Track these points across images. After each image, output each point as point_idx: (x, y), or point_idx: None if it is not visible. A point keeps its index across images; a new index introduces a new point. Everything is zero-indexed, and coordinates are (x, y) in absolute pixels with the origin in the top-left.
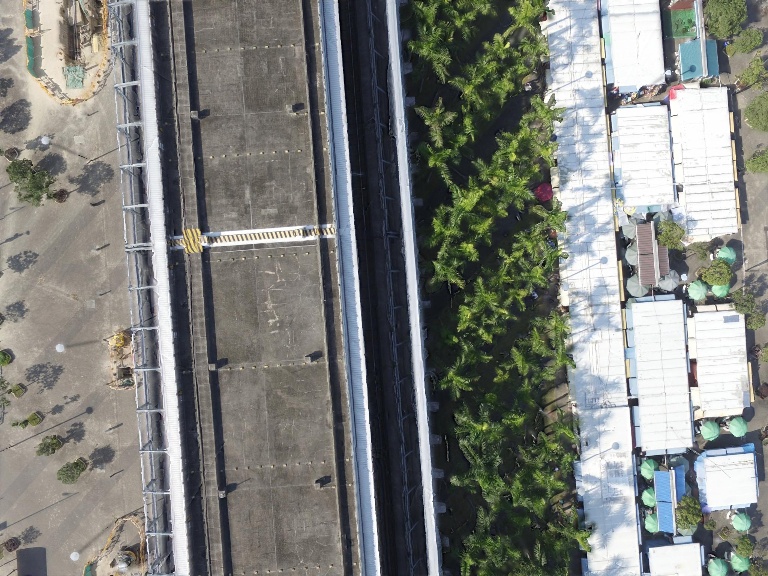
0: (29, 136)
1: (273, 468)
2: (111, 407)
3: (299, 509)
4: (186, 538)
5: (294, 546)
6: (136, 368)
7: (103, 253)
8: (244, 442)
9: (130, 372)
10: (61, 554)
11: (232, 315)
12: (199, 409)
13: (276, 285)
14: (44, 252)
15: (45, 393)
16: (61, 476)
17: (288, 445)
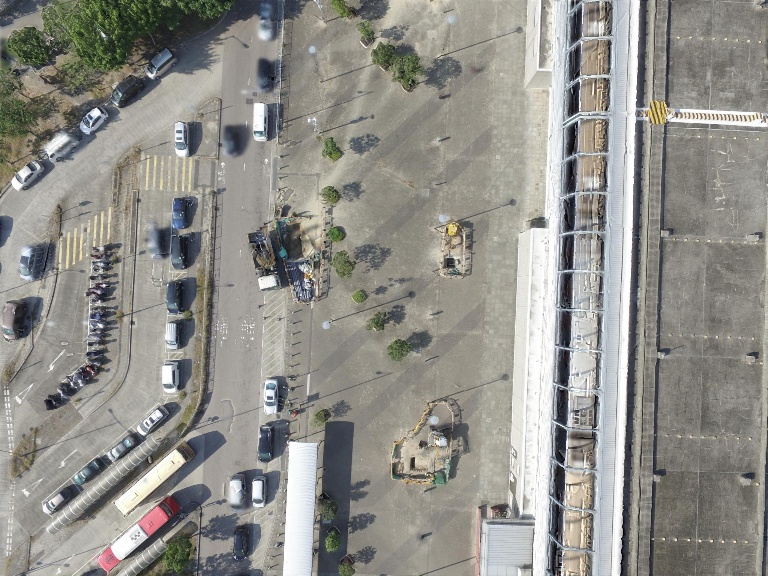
0: (385, 25)
1: (706, 338)
2: (434, 294)
3: (726, 380)
4: None
5: (718, 415)
6: (578, 230)
7: (443, 145)
8: (681, 310)
9: (454, 263)
10: (368, 431)
11: (682, 188)
12: (646, 272)
13: (726, 165)
14: (386, 137)
15: (371, 273)
16: (394, 351)
17: (722, 318)
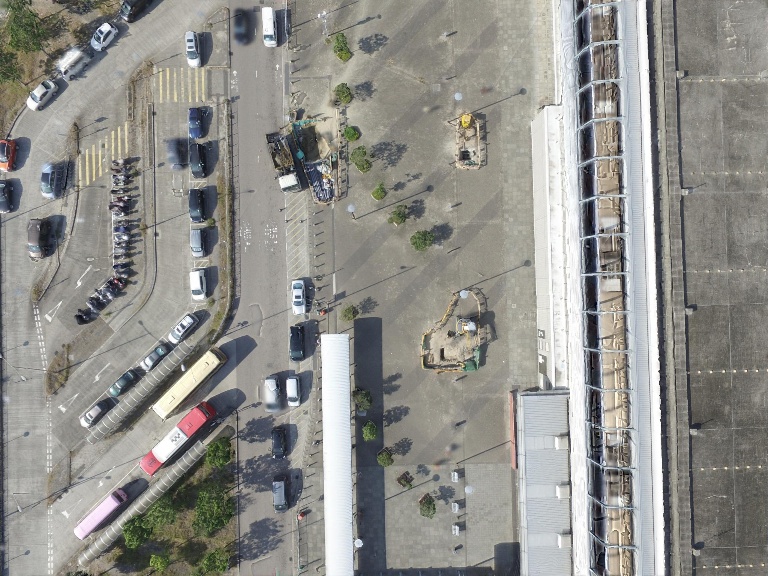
0: None
1: (727, 174)
2: (452, 186)
3: (749, 215)
4: (654, 229)
5: (743, 249)
6: (595, 80)
7: (450, 40)
8: (701, 149)
9: (469, 155)
10: (397, 325)
11: (694, 31)
12: (665, 113)
13: (735, 6)
14: (394, 36)
15: (389, 170)
16: (417, 240)
17: (741, 154)
